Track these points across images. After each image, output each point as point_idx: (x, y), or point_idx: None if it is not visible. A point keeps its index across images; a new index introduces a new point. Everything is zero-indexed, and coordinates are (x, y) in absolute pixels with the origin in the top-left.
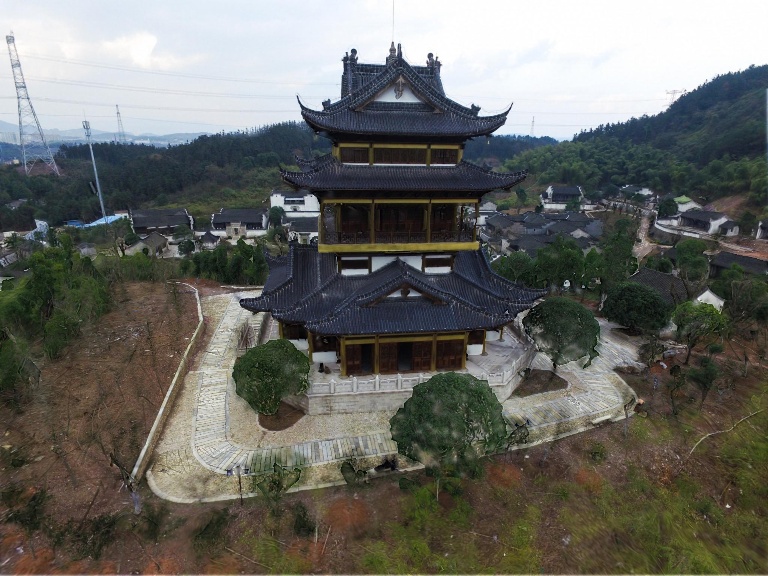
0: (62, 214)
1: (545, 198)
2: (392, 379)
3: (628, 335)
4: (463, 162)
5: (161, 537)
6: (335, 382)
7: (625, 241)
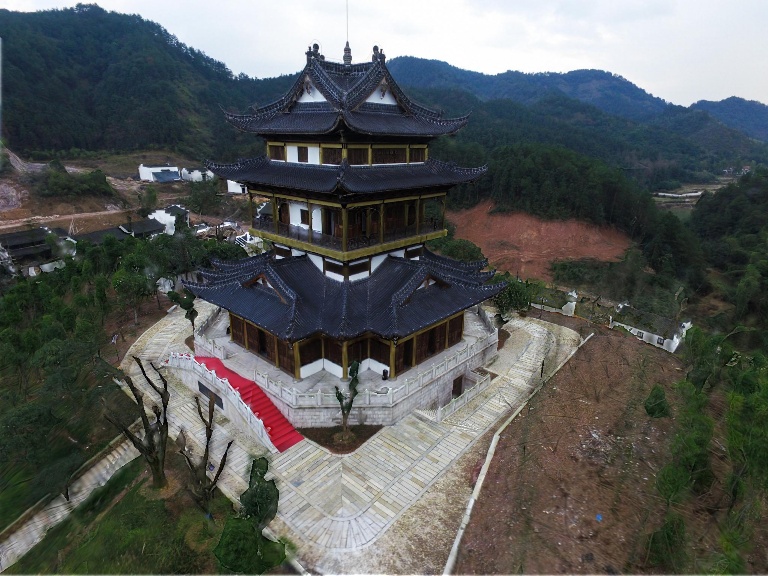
0: None
1: None
2: None
3: None
4: None
5: None
6: None
7: None
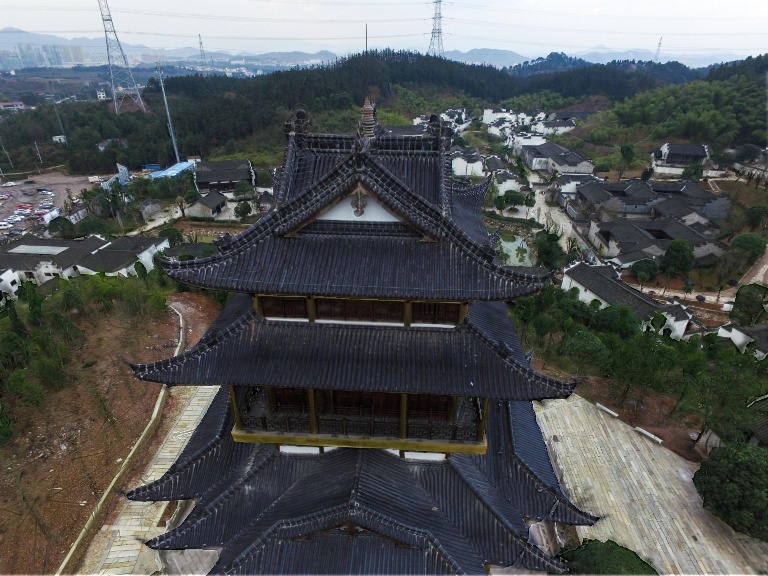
0: (141, 158)
1: (657, 158)
2: None
3: (733, 529)
4: (467, 325)
5: None
6: None
7: (756, 245)
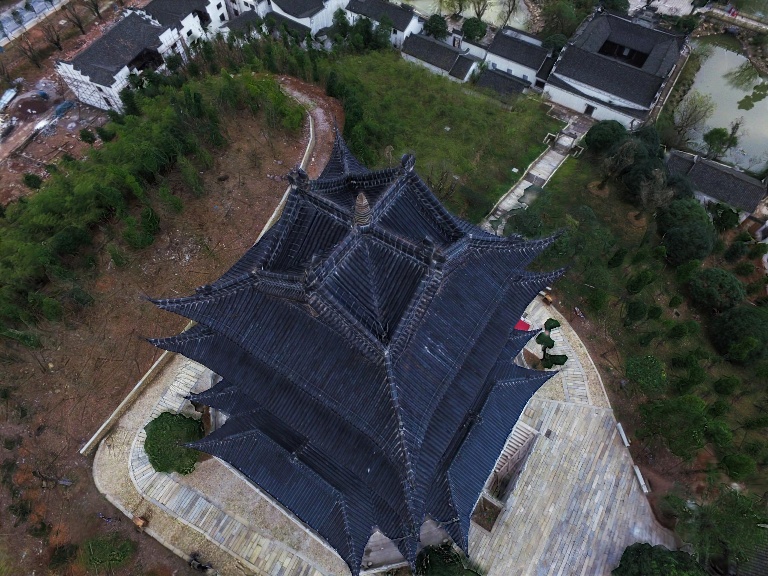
0: None
1: None
2: (269, 499)
3: None
4: None
5: (43, 538)
6: (229, 467)
7: None
